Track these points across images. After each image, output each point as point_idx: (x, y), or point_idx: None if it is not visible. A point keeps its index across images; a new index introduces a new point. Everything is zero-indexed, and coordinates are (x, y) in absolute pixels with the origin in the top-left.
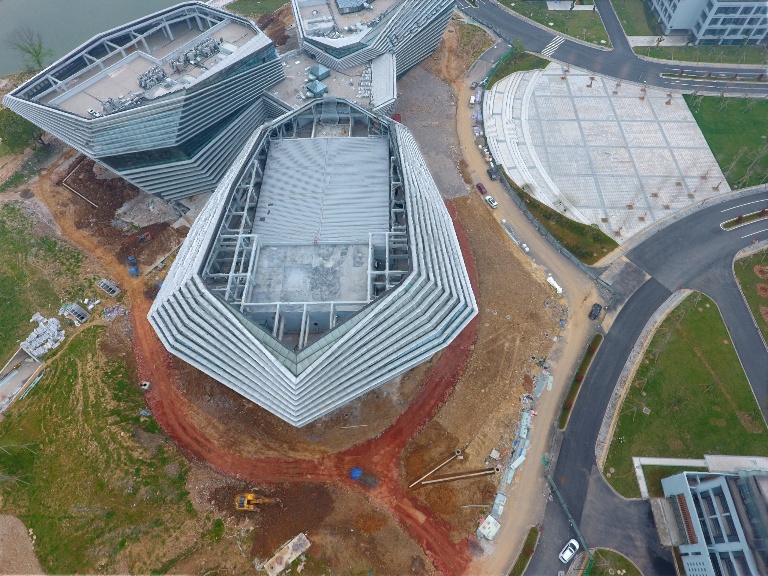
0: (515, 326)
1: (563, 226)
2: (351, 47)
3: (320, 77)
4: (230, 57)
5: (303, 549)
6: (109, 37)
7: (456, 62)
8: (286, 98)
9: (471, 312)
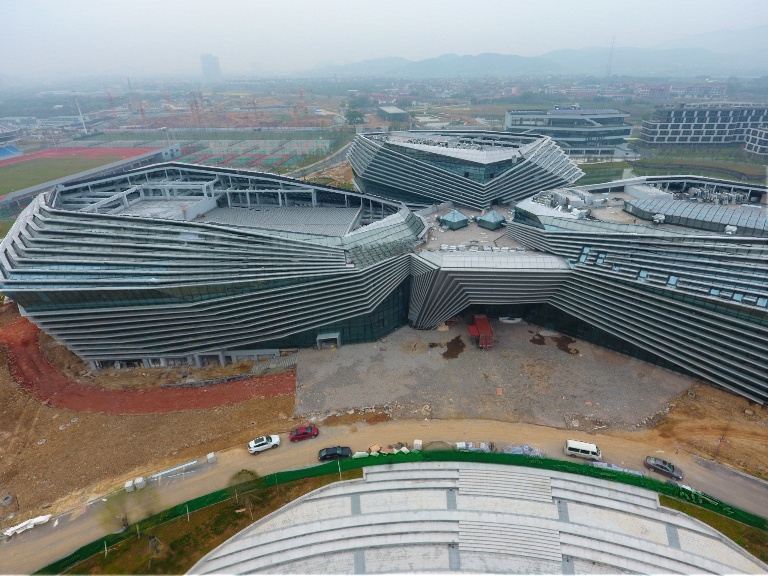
0: (21, 448)
1: (136, 575)
2: (528, 216)
3: (481, 222)
4: (437, 148)
5: (6, 300)
6: (486, 135)
7: (763, 449)
8: (442, 213)
9: (1, 288)
